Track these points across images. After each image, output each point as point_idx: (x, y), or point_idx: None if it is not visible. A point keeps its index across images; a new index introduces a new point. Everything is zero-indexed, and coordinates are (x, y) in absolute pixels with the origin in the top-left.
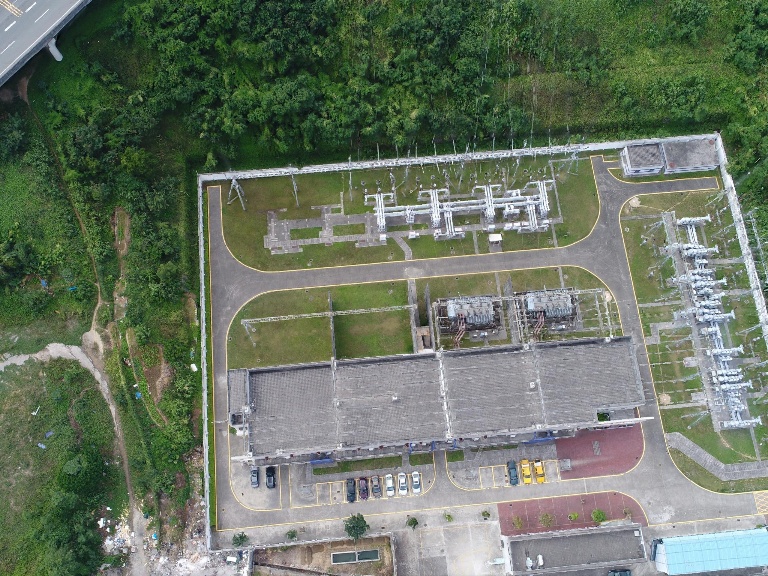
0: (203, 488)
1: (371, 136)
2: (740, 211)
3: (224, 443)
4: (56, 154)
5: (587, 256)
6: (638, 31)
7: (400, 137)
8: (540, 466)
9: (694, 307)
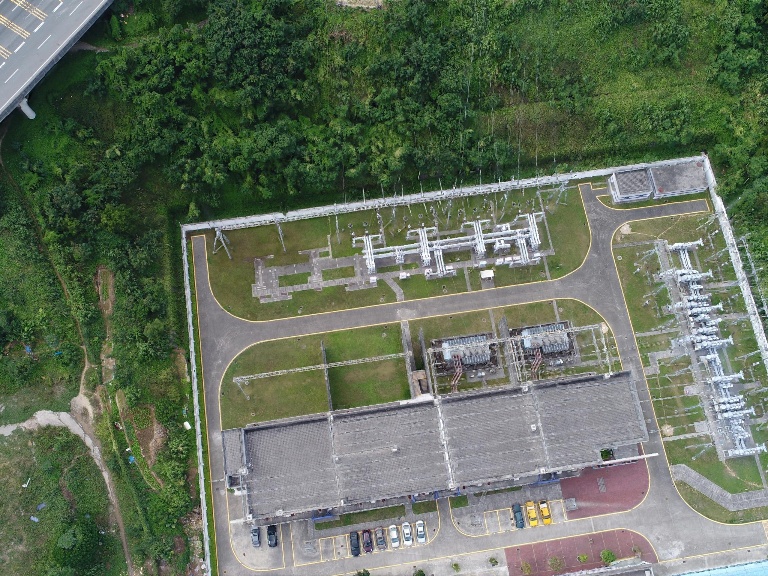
0: (203, 551)
1: (356, 178)
2: (732, 233)
3: (222, 502)
4: (34, 215)
5: (581, 287)
6: (619, 56)
7: (385, 177)
8: (546, 507)
9: (692, 335)
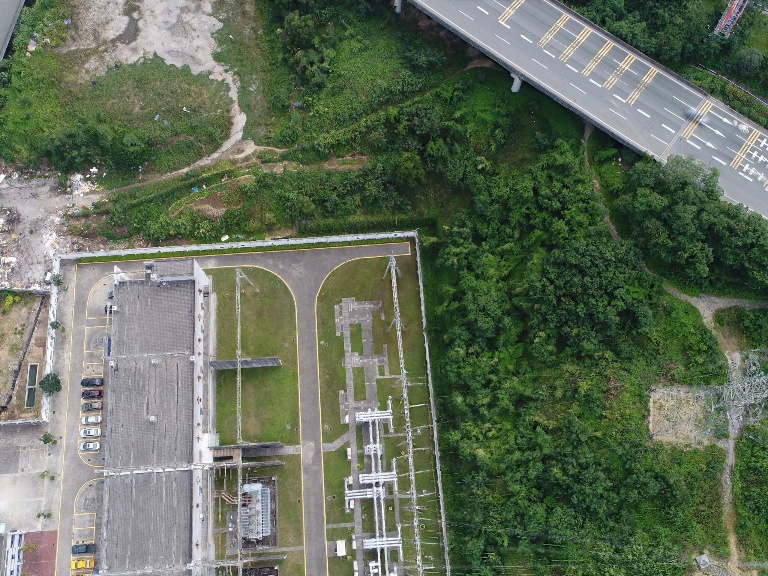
0: None
1: None
2: None
3: None
4: None
5: None
6: None
7: (456, 437)
8: None
9: None
